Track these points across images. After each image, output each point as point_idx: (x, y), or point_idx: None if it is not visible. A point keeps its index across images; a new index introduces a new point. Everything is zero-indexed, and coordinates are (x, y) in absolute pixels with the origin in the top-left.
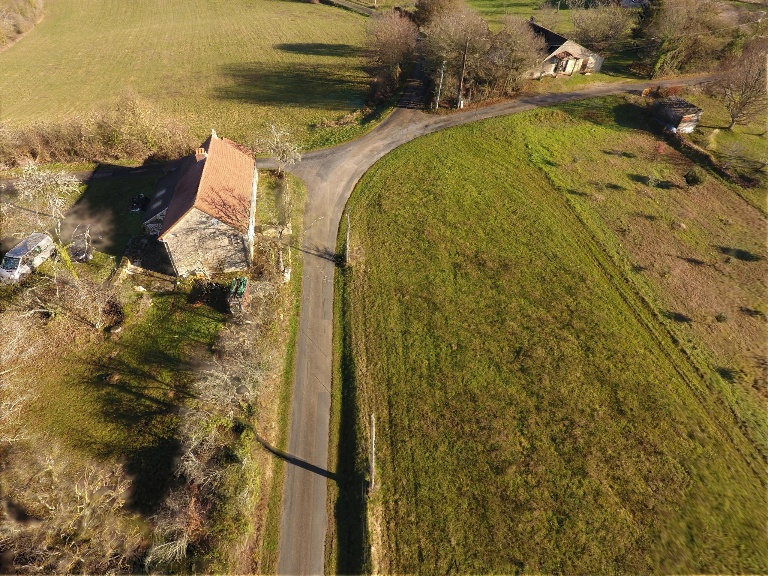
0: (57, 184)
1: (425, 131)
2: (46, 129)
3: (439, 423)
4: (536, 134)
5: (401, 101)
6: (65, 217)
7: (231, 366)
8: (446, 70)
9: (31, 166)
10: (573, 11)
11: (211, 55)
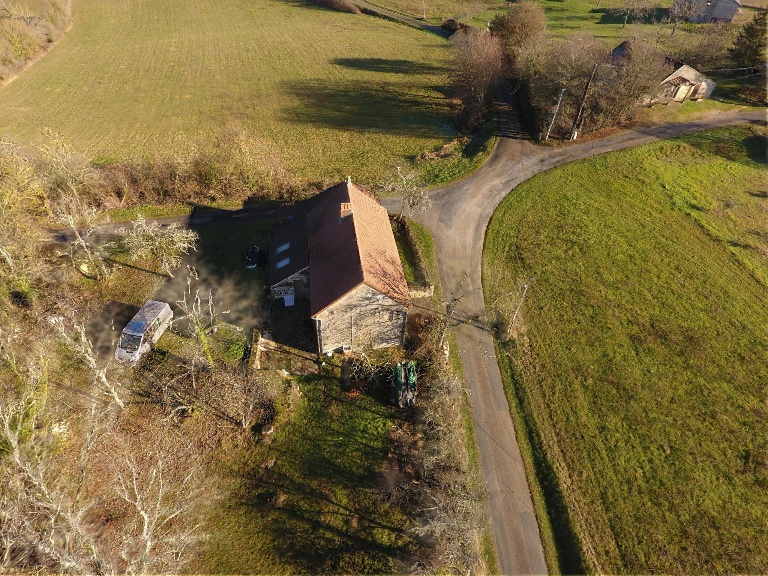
0: (173, 241)
1: (543, 167)
2: (135, 166)
3: (683, 560)
4: (668, 172)
5: (500, 129)
6: (173, 275)
7: (432, 491)
8: (562, 98)
9: (139, 218)
10: (657, 28)
11: (265, 70)
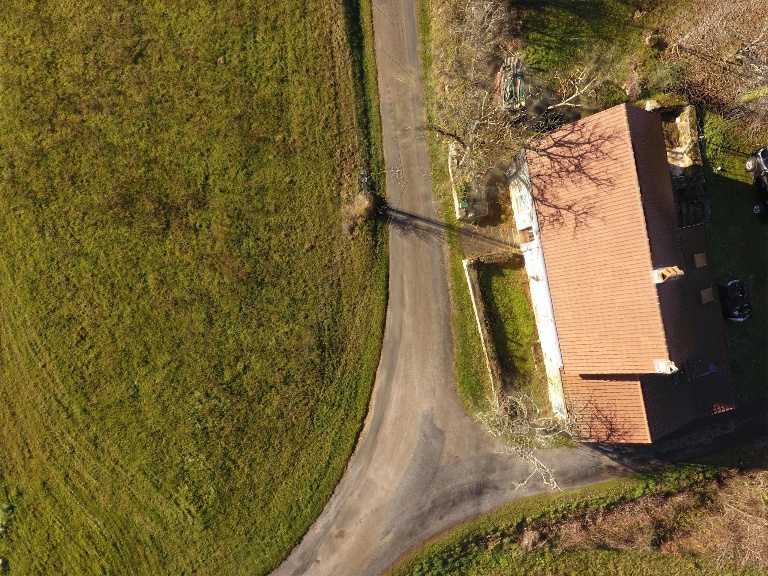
0: None
1: None
2: None
3: None
4: None
5: None
6: None
7: None
8: None
9: None
10: None
11: None
